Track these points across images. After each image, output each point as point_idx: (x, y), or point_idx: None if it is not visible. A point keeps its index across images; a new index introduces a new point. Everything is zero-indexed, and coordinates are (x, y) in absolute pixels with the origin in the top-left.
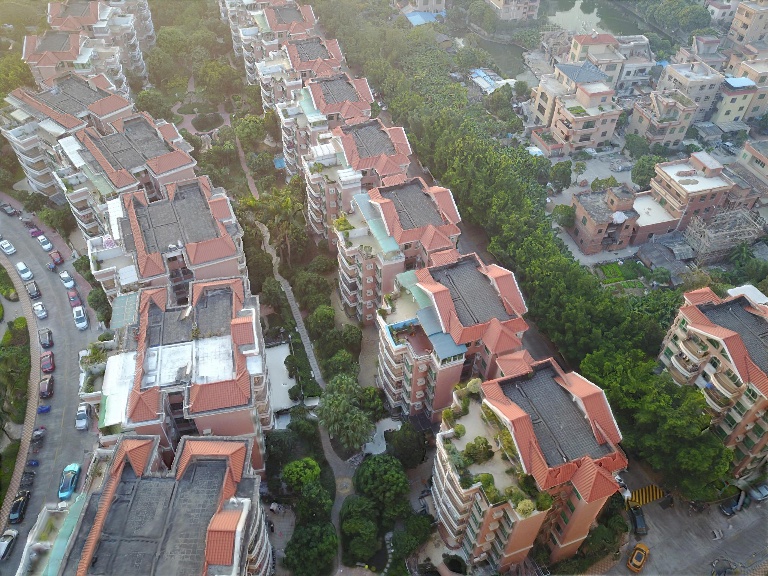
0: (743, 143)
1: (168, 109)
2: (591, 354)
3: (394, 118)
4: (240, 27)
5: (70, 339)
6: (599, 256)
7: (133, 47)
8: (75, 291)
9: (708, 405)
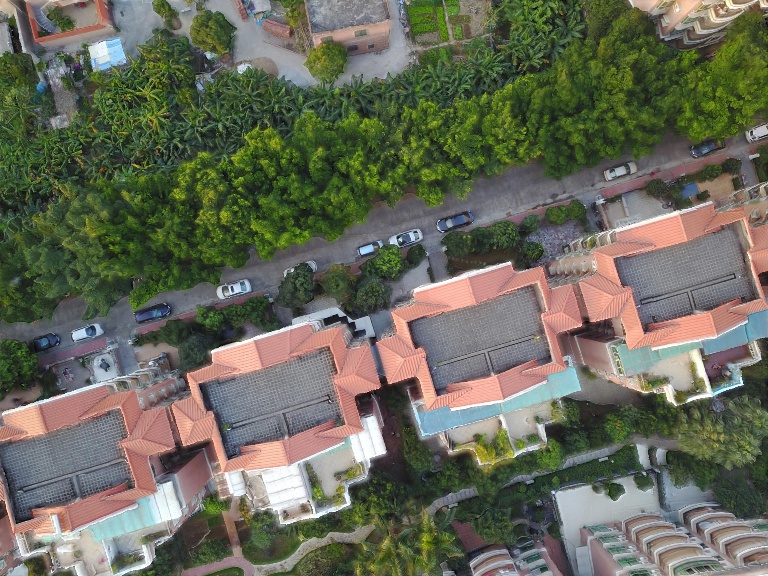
0: None
1: None
2: (680, 118)
3: (27, 319)
4: None
5: None
6: (390, 27)
7: None
8: None
9: None
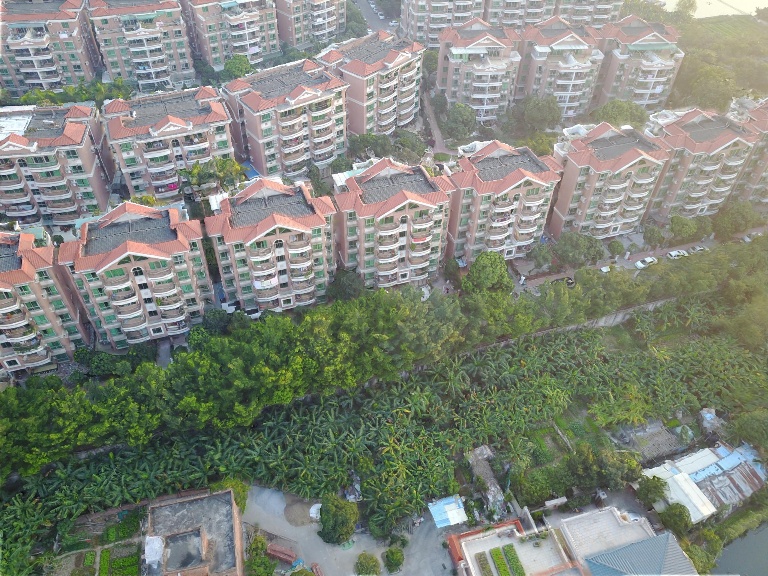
0: None
1: (458, 130)
2: None
3: None
4: (593, 126)
5: None
6: None
7: (561, 88)
8: None
9: None
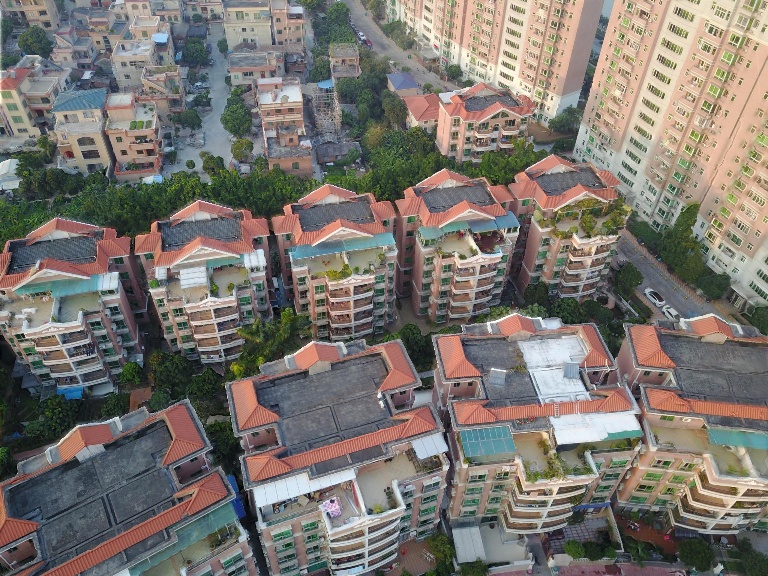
0: (204, 77)
1: None
2: None
3: None
4: None
5: None
6: None
7: None
8: None
9: (506, 151)
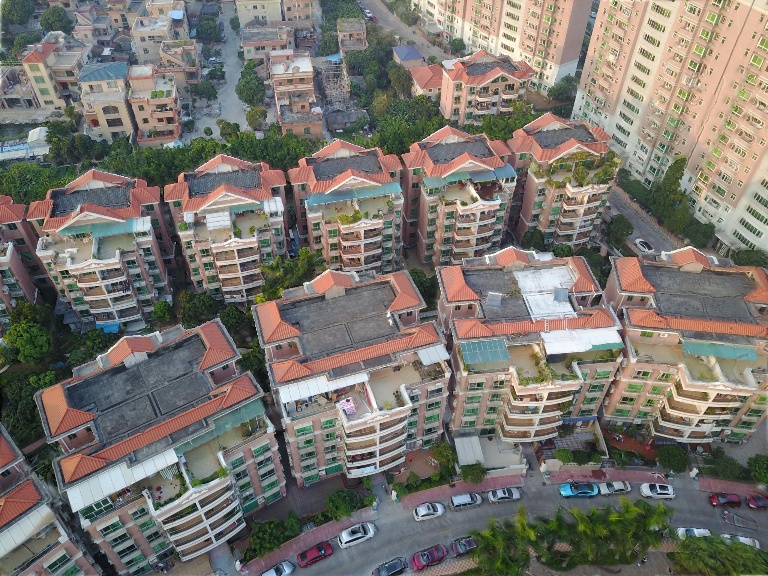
0: (218, 52)
1: None
2: None
3: None
4: None
5: (390, 542)
6: None
7: None
8: (307, 551)
9: (506, 114)
